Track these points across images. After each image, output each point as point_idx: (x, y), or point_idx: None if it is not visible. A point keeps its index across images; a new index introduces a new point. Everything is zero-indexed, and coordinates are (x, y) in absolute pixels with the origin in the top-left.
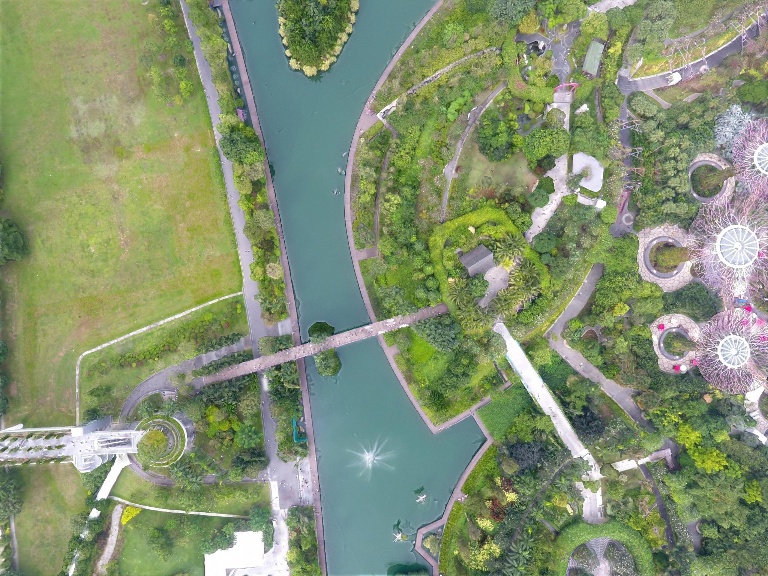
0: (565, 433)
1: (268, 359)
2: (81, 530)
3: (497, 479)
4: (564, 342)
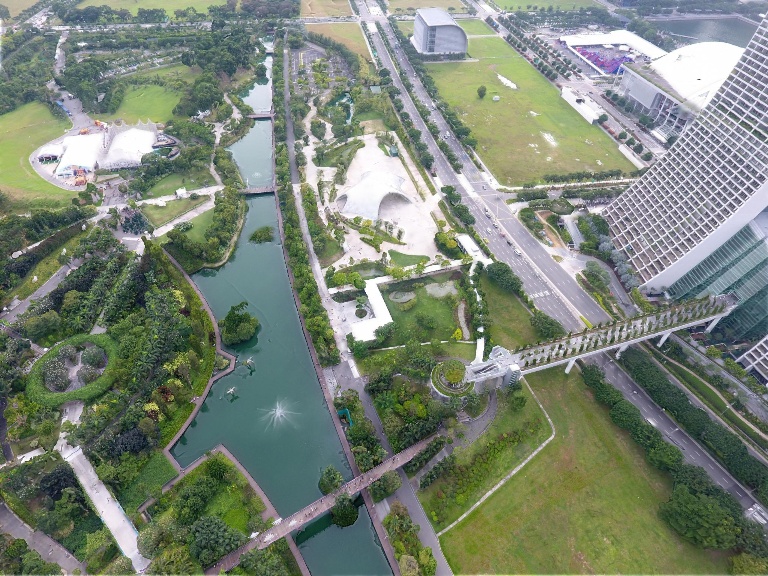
0: (86, 472)
1: (388, 469)
2: (483, 317)
3: (162, 419)
4: (66, 575)
